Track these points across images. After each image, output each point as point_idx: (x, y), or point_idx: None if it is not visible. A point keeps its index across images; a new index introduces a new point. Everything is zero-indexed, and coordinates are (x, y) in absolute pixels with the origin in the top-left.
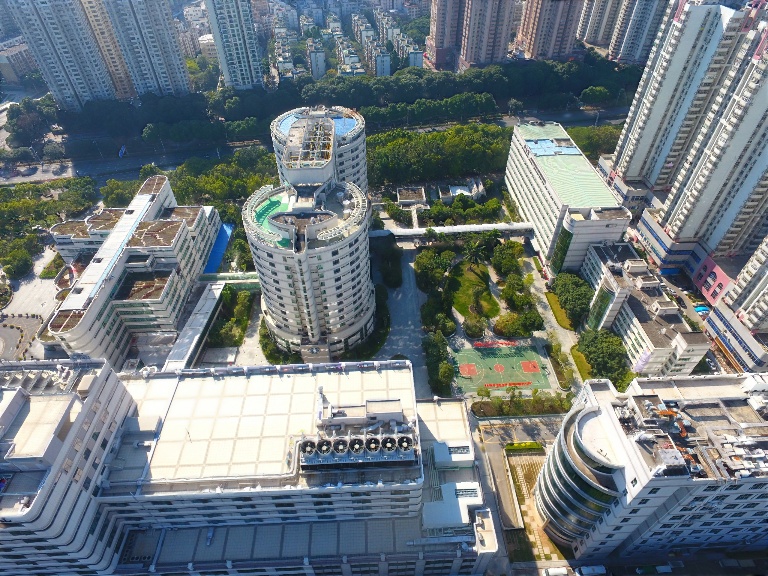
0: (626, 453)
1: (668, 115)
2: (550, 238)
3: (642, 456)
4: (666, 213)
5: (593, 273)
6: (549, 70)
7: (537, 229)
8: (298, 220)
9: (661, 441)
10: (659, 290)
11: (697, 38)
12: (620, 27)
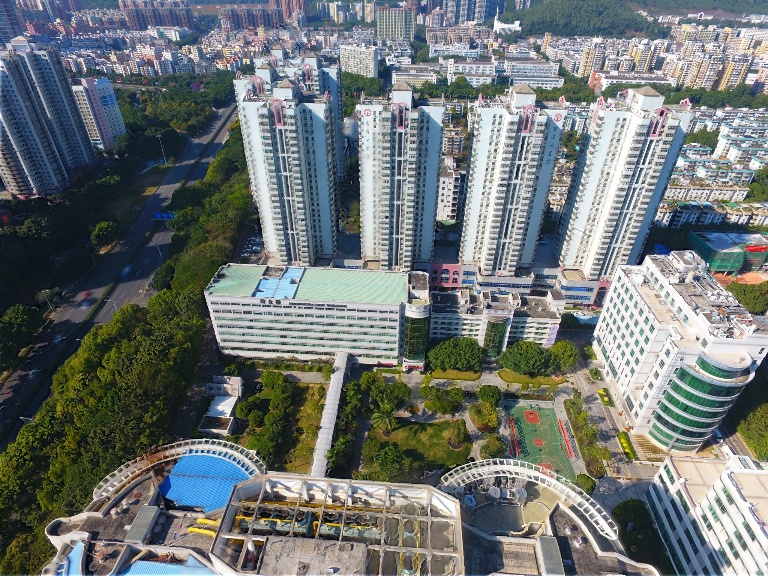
0: (748, 345)
1: (309, 199)
2: (394, 340)
3: (763, 335)
4: (388, 260)
5: (452, 328)
6: (15, 240)
7: (358, 349)
8: (582, 571)
9: (743, 323)
10: (491, 296)
11: (302, 133)
12: (7, 163)
